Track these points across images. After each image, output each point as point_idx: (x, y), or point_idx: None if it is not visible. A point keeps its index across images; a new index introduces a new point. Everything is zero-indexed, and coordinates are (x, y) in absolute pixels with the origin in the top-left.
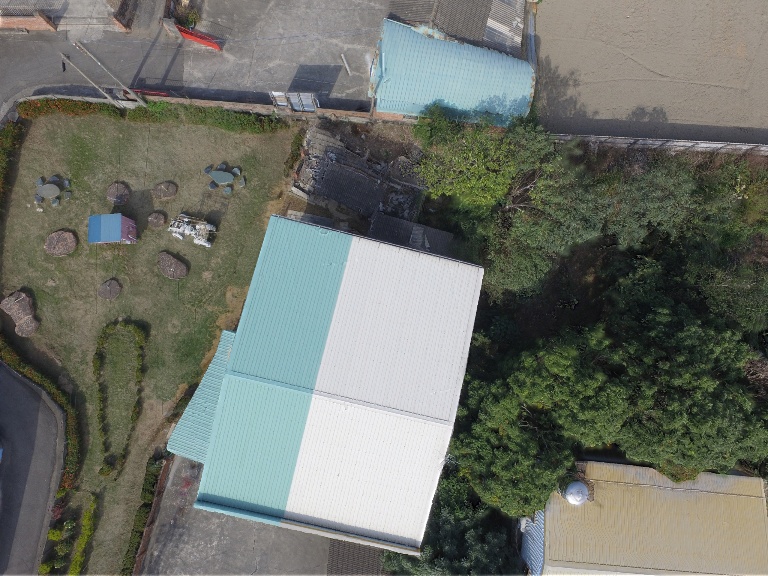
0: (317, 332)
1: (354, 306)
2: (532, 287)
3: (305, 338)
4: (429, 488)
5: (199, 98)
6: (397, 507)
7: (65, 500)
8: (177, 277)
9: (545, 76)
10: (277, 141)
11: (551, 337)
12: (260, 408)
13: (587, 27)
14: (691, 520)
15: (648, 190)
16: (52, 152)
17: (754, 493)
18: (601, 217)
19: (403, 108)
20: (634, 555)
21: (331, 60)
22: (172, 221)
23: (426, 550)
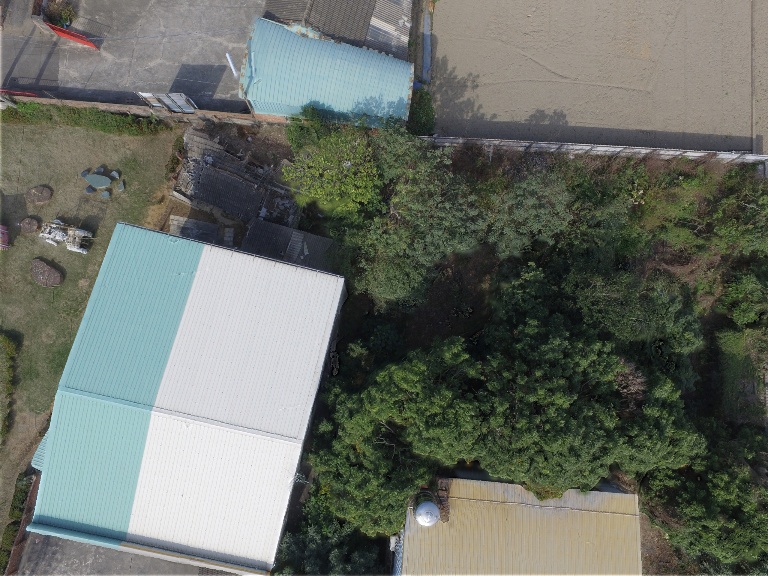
0: (160, 345)
1: (202, 318)
2: (411, 296)
3: (147, 352)
4: (279, 508)
5: (71, 99)
6: (246, 528)
7: None
8: (50, 285)
9: (439, 77)
10: (159, 143)
11: (425, 348)
12: (96, 426)
13: (486, 26)
14: (571, 537)
15: (541, 195)
16: None
17: (627, 511)
18: (489, 223)
19: (281, 110)
20: (501, 575)
21: (215, 59)
22: (44, 227)
23: (285, 572)
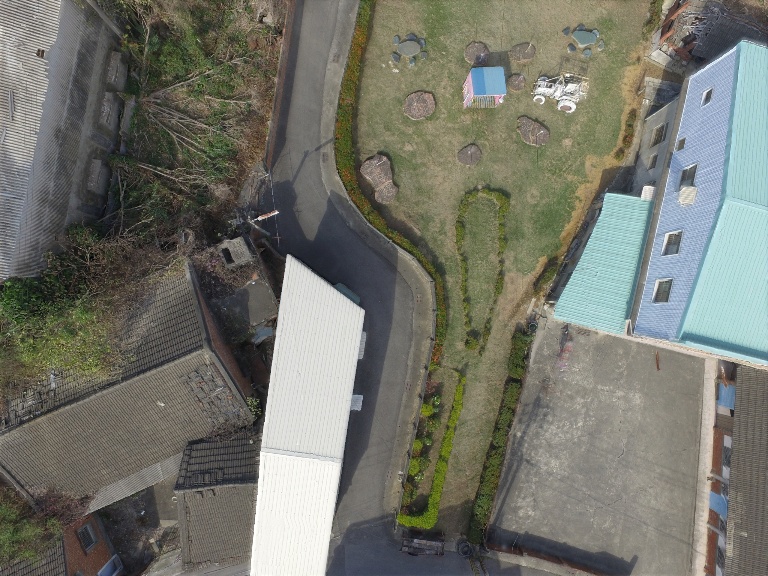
0: None
1: None
2: None
3: None
4: None
5: None
6: None
7: (430, 376)
8: (540, 143)
9: None
10: (633, 4)
11: None
12: (758, 238)
13: None
14: None
15: None
16: (407, 9)
17: None
18: None
19: None
20: None
21: None
22: (539, 81)
23: None
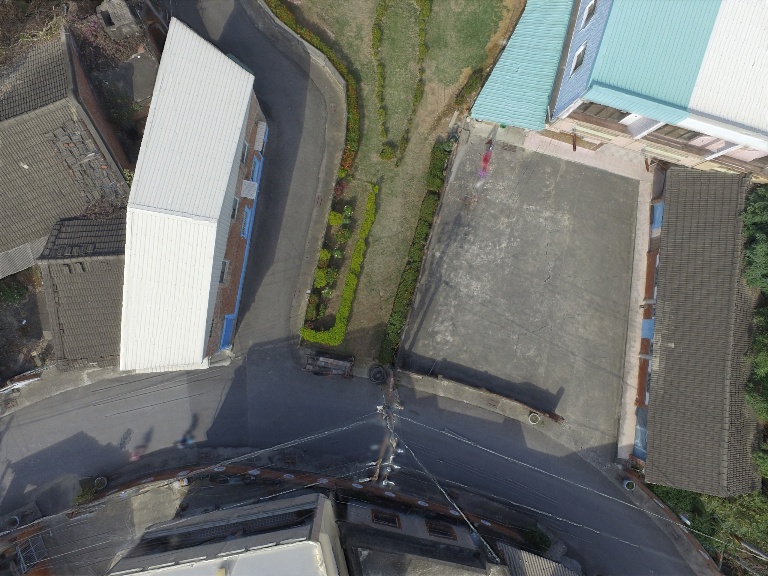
0: None
1: None
2: None
3: None
4: None
5: None
6: None
7: (341, 186)
8: None
9: None
10: None
11: None
12: None
13: None
14: None
15: None
16: None
17: None
18: None
19: None
20: None
21: None
22: None
23: None
